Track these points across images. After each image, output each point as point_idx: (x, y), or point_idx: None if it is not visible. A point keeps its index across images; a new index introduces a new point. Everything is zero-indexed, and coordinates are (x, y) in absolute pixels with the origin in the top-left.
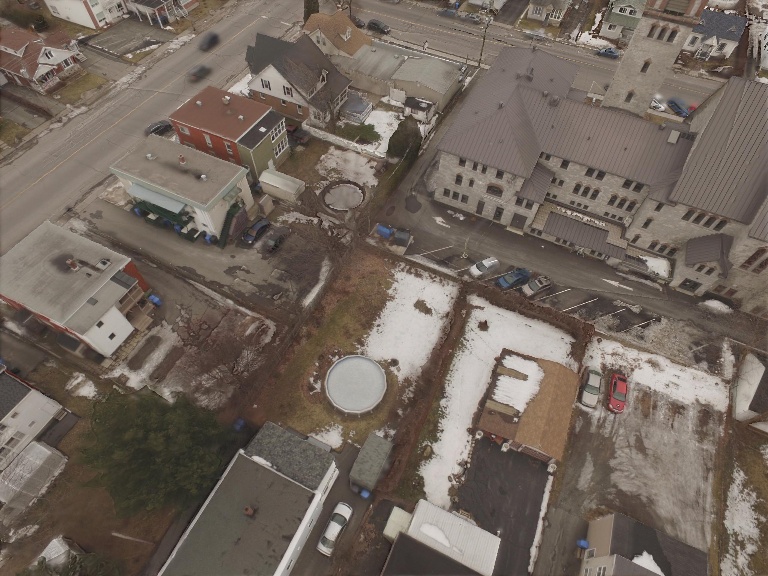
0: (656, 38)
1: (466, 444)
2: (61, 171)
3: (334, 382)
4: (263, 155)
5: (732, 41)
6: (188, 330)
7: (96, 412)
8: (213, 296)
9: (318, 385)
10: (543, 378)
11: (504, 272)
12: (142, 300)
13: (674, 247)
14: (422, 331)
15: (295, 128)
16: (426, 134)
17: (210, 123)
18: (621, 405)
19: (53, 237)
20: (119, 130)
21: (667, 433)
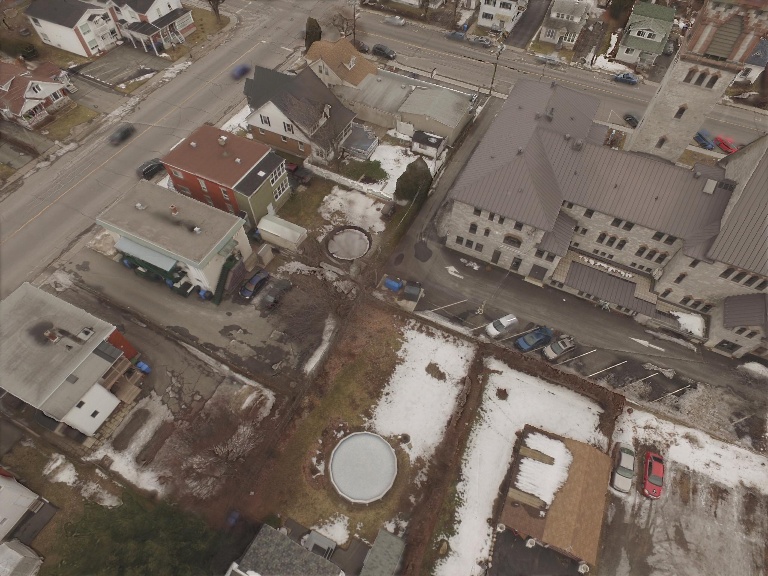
0: (693, 83)
1: (486, 538)
2: (47, 216)
3: (339, 464)
4: (262, 200)
5: (758, 66)
6: (179, 402)
7: (63, 551)
8: (207, 361)
9: (321, 467)
10: (571, 463)
11: (523, 330)
12: (129, 369)
13: (709, 303)
14: (435, 400)
15: (296, 167)
16: (436, 171)
17: (205, 167)
18: (658, 490)
19: (32, 301)
20: (110, 169)
21: (710, 523)
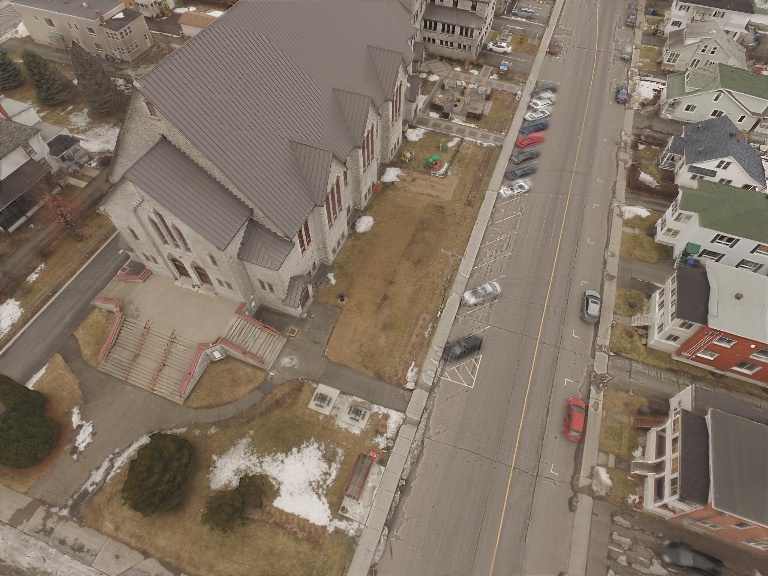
0: None
1: None
2: None
3: None
4: None
5: (685, 160)
6: None
7: None
8: None
9: None
10: None
11: None
12: None
13: None
14: None
15: None
16: None
17: None
18: None
19: None
20: None
21: None
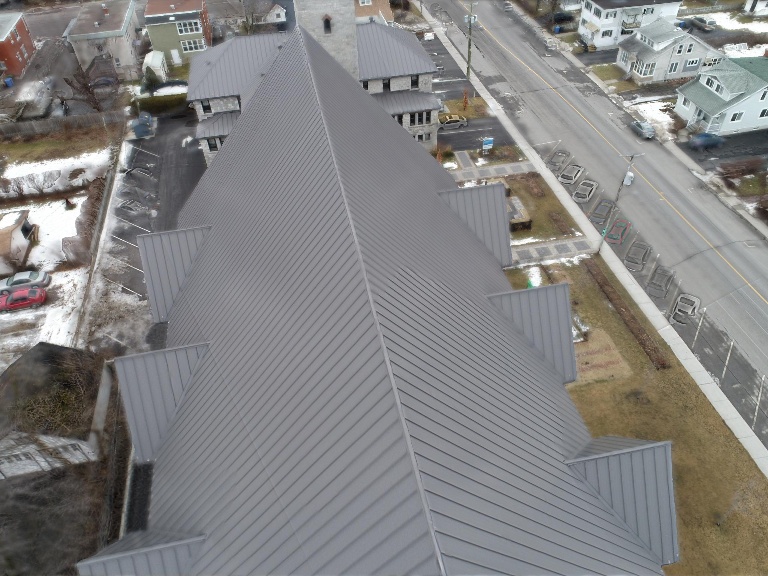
0: None
1: None
2: None
3: None
4: (165, 40)
5: None
6: None
7: None
8: None
9: None
10: None
11: None
12: None
13: None
14: None
15: None
16: None
17: (158, 4)
18: (1, 305)
19: None
20: None
21: None
